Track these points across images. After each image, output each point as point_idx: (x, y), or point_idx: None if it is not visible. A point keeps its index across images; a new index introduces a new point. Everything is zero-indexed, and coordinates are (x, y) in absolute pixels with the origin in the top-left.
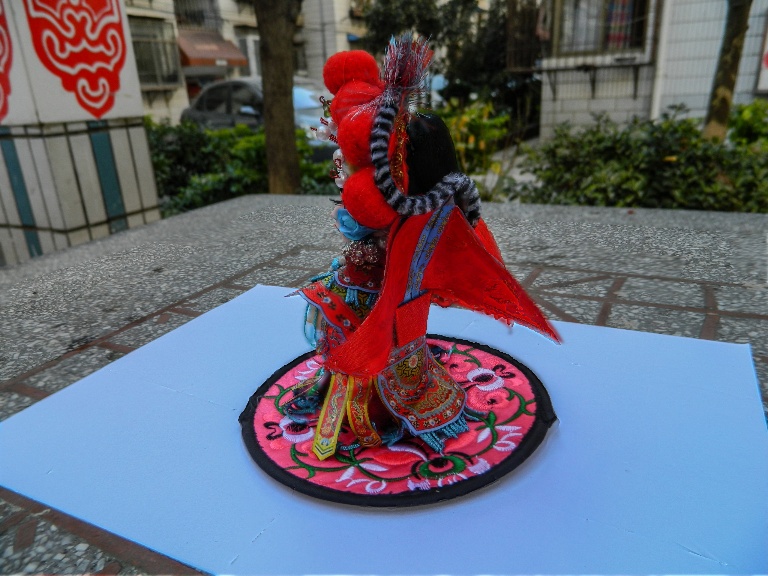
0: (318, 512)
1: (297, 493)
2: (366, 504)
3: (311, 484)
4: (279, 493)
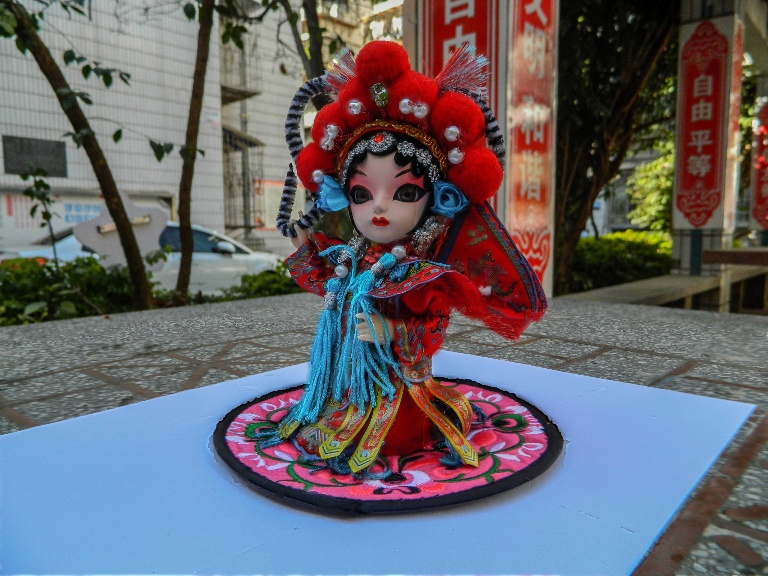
0: (554, 482)
1: (535, 480)
2: (560, 450)
3: (526, 469)
4: (519, 500)
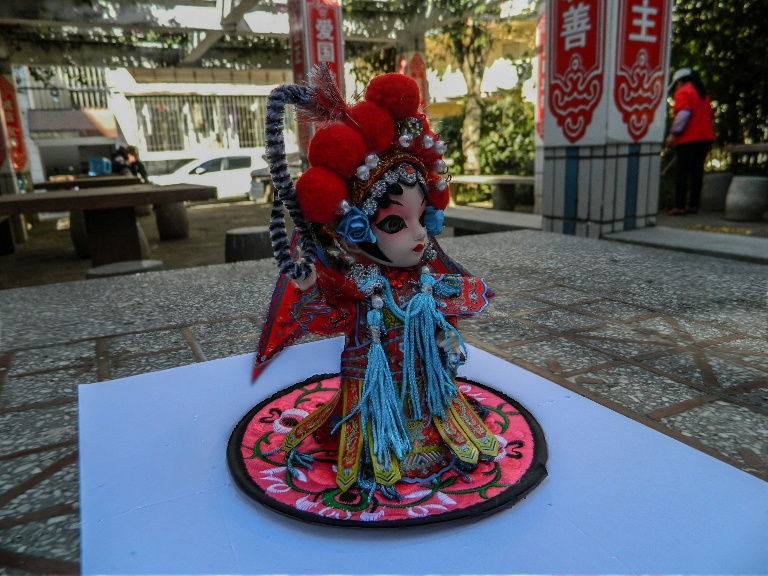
0: None
1: None
2: None
3: (505, 399)
4: None
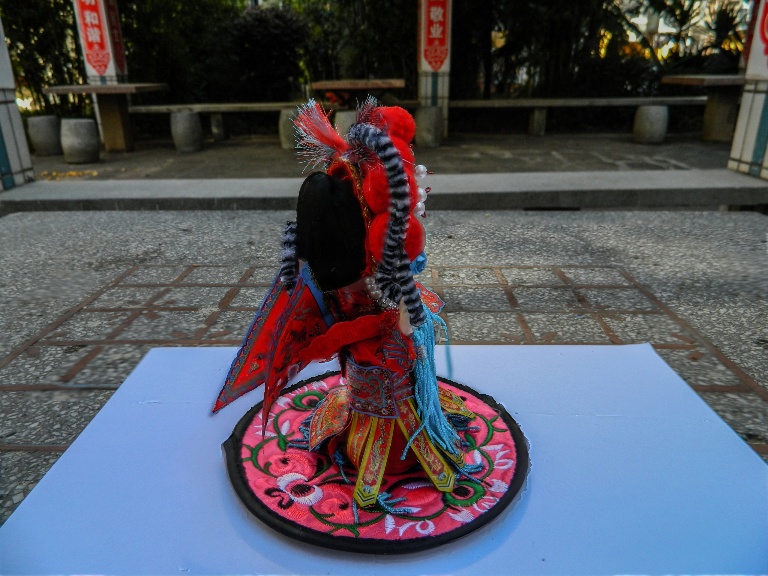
0: None
1: None
2: None
3: None
4: None
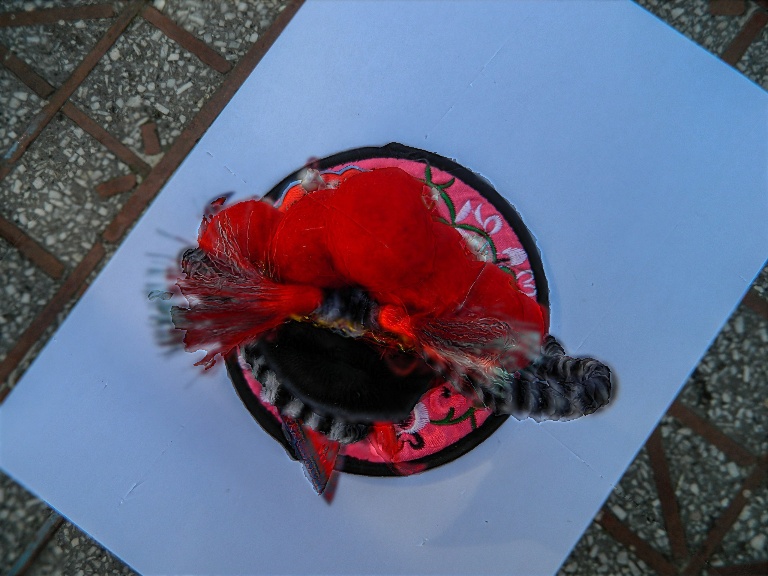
0: None
1: None
2: None
3: None
4: None
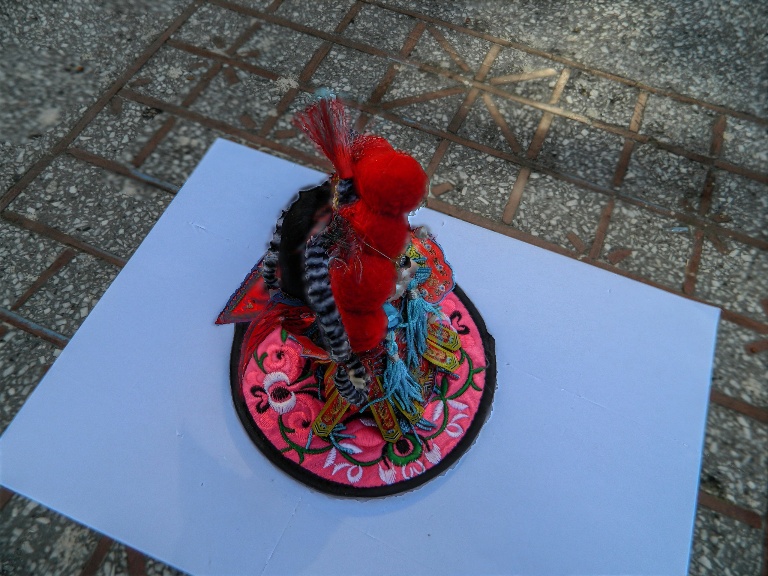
0: None
1: None
2: None
3: None
4: None
